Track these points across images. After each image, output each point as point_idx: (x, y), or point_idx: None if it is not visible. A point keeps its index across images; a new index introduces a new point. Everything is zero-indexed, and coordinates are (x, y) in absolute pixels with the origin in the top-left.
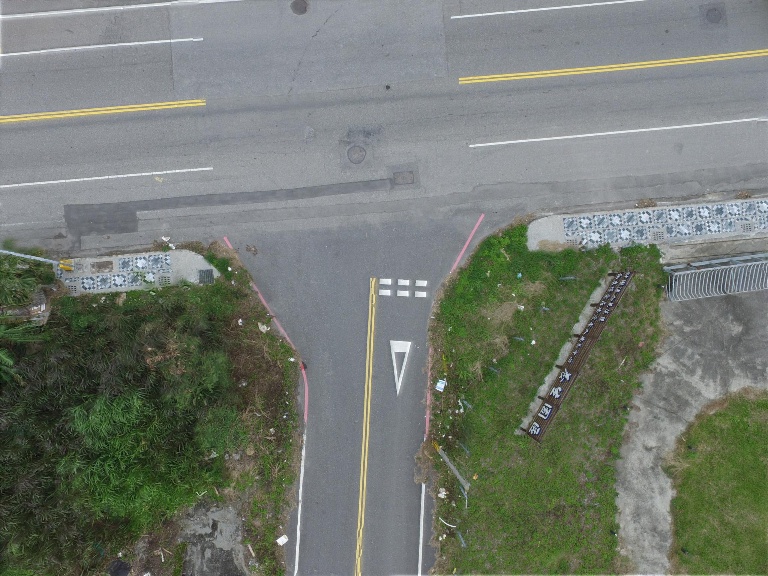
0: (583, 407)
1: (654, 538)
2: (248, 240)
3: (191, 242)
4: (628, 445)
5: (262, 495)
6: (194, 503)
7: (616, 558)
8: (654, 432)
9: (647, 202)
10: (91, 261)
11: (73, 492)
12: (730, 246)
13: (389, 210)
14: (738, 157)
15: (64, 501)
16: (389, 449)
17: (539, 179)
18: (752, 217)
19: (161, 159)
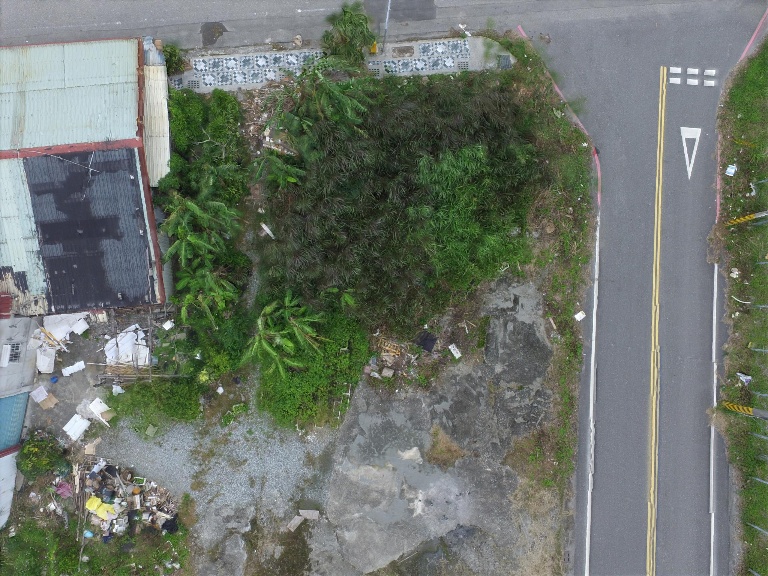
0: None
1: None
2: (542, 28)
3: (486, 30)
4: None
5: (562, 271)
6: (496, 278)
7: None
8: None
9: None
10: (392, 46)
11: None
12: None
13: (678, 1)
14: None
15: (406, 250)
16: (682, 230)
17: None
18: None
19: None
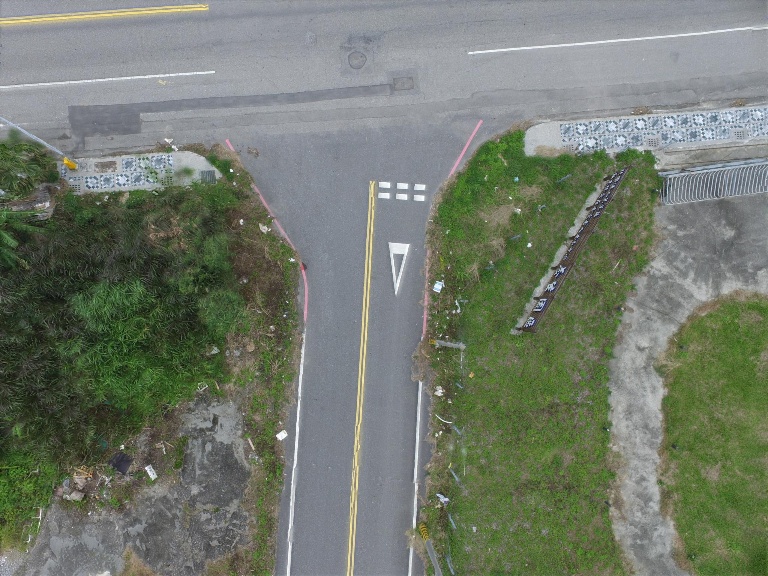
0: (577, 308)
1: (645, 435)
2: (250, 143)
3: (193, 144)
4: (621, 345)
5: (262, 390)
6: (195, 398)
7: (608, 454)
8: (647, 333)
9: (643, 110)
10: (95, 161)
11: (77, 375)
12: (724, 153)
13: (389, 115)
14: (733, 66)
15: (68, 383)
16: (387, 348)
17: (537, 86)
18: (746, 125)
19: (164, 62)
